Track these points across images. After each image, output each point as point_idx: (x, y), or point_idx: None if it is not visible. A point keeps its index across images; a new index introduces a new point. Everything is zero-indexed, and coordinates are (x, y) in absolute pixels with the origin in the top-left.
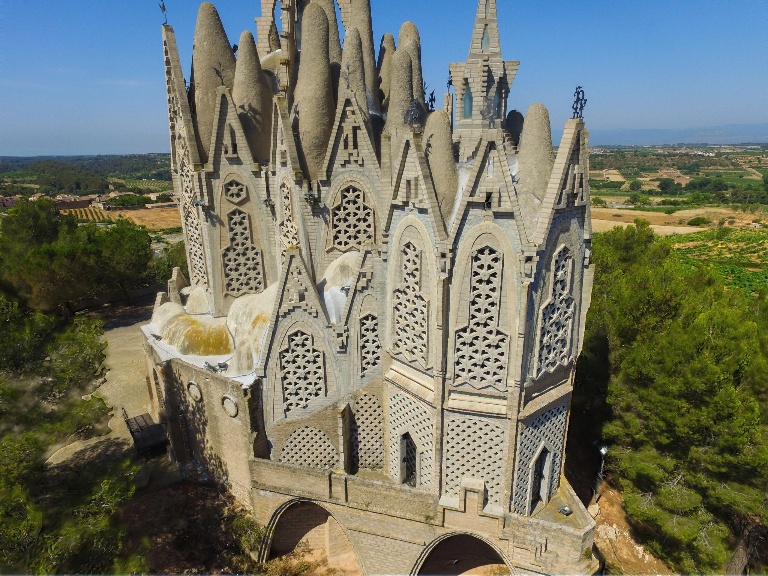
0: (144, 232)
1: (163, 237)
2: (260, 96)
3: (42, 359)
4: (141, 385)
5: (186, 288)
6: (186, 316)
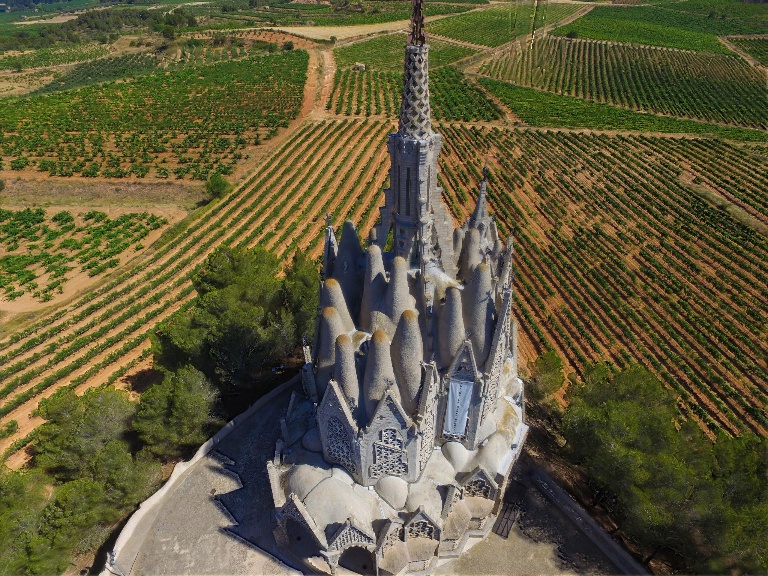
0: None
1: None
2: None
3: (587, 437)
4: (466, 573)
5: (425, 506)
6: (500, 427)
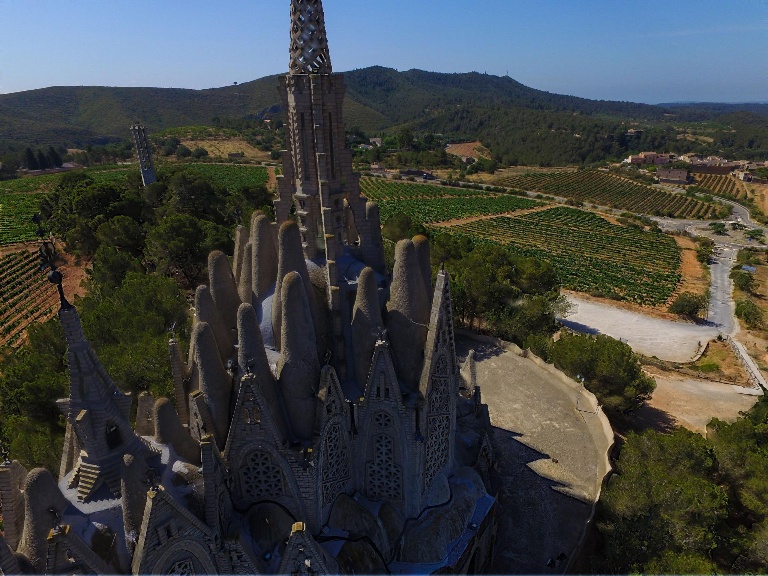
0: (457, 290)
1: (763, 233)
2: (247, 293)
3: None
4: None
5: None
6: None
